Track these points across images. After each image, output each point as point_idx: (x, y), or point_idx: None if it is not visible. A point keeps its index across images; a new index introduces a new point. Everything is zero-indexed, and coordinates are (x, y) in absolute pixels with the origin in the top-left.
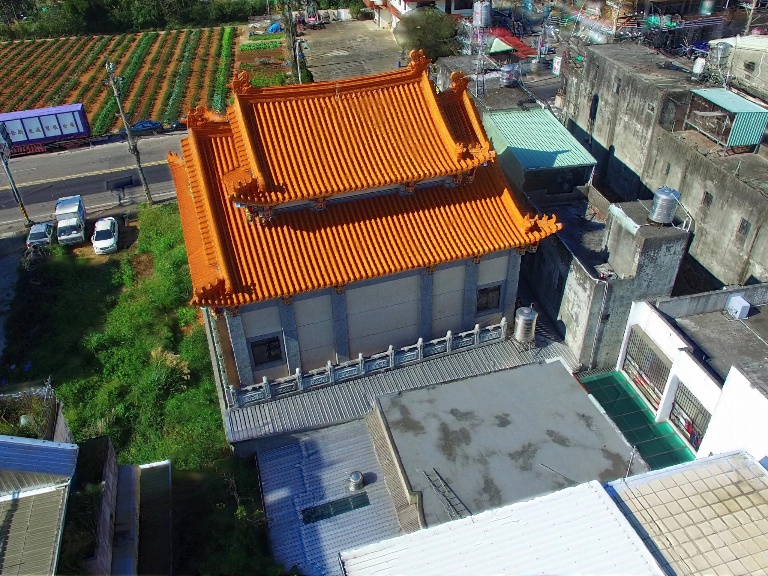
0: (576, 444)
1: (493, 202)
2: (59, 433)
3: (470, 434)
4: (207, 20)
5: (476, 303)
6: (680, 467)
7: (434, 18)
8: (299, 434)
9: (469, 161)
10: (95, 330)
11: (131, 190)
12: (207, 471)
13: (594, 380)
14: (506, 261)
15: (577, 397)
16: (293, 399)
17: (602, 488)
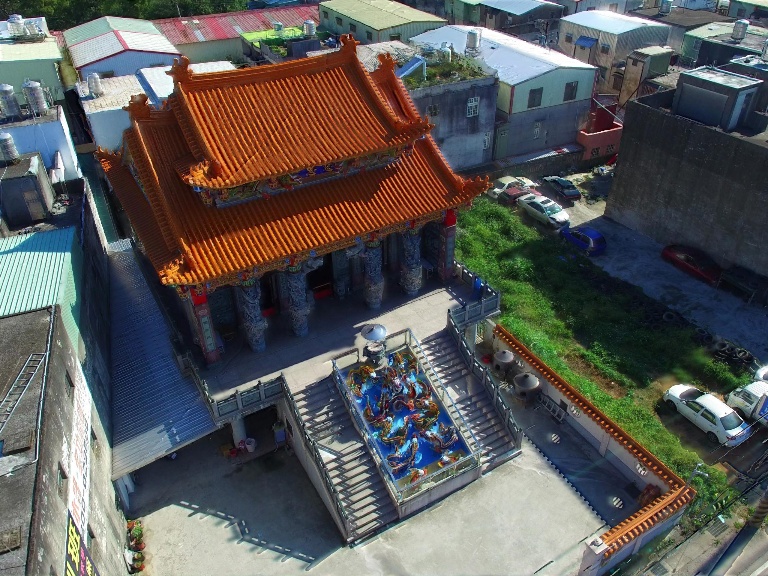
0: None
1: None
2: None
3: None
4: None
5: None
6: None
7: None
8: None
9: None
10: (543, 286)
11: None
12: None
13: None
14: None
15: None
16: None
17: None
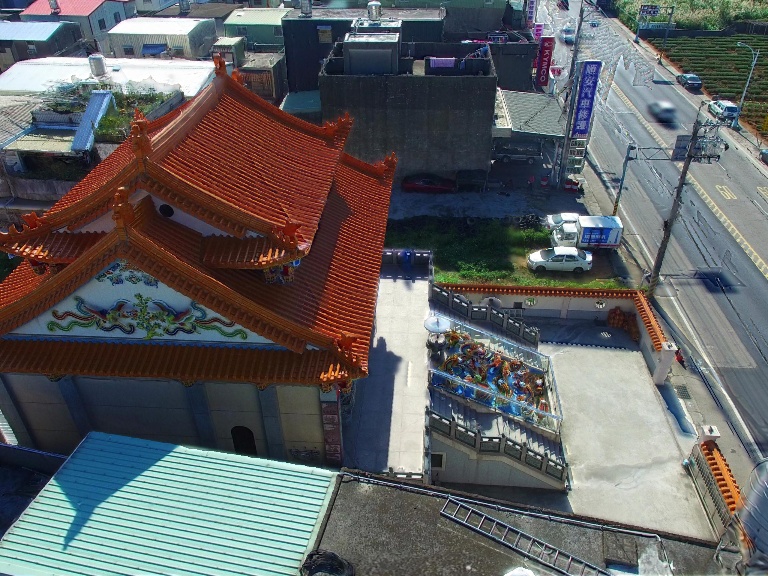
0: None
1: None
2: None
3: None
4: None
5: None
6: None
7: None
8: None
9: None
10: None
11: (695, 283)
12: None
13: None
14: None
15: None
16: None
17: None
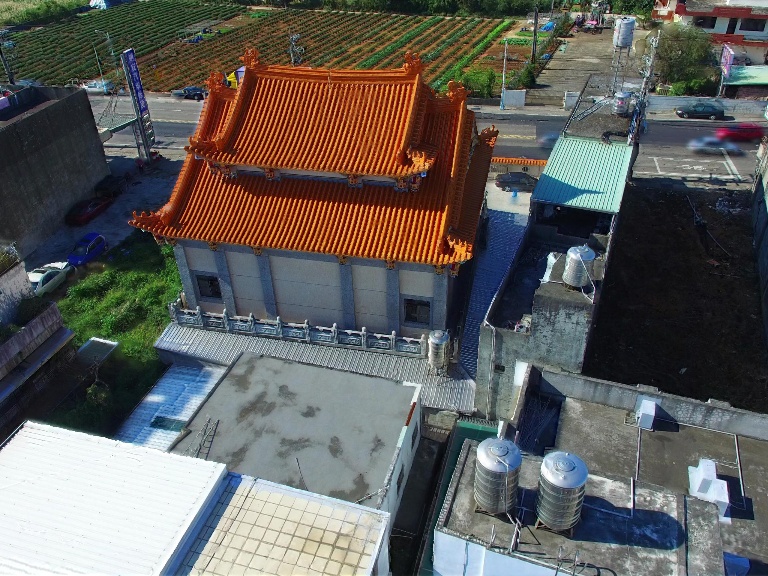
0: (344, 458)
1: (431, 216)
2: (12, 283)
3: (274, 409)
4: (494, 11)
5: (403, 311)
6: (315, 496)
7: (686, 35)
8: (205, 362)
9: (406, 168)
10: None
11: None
12: (137, 362)
13: (477, 429)
14: (432, 278)
15: (393, 423)
16: (219, 334)
17: (220, 472)
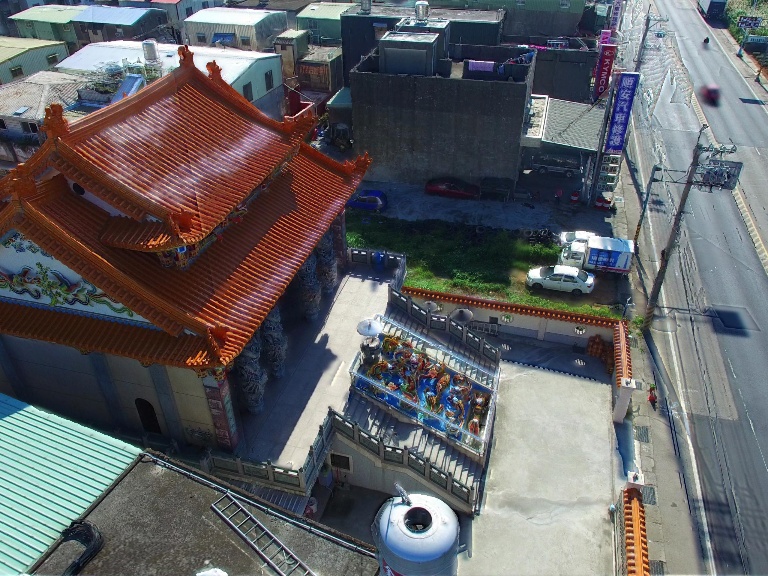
0: None
1: None
2: None
3: None
4: None
5: None
6: None
7: None
8: None
9: None
10: (378, 248)
11: (702, 321)
12: None
13: None
14: None
15: None
16: None
17: None
